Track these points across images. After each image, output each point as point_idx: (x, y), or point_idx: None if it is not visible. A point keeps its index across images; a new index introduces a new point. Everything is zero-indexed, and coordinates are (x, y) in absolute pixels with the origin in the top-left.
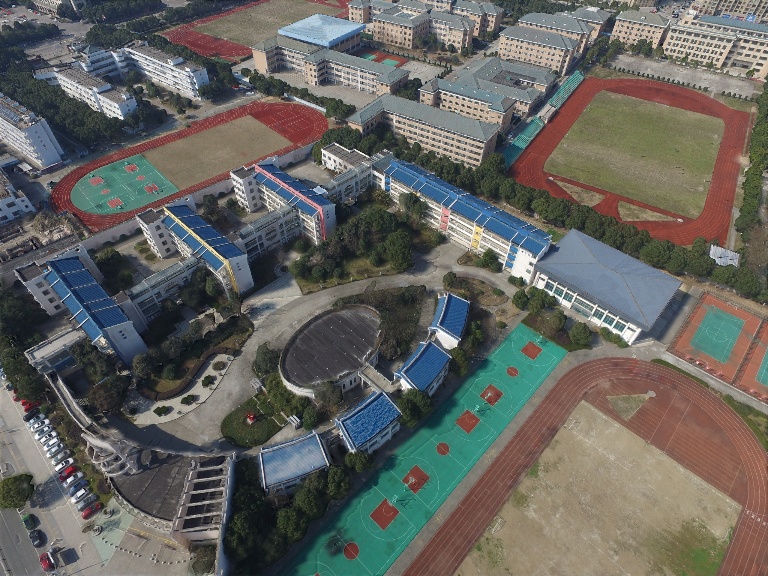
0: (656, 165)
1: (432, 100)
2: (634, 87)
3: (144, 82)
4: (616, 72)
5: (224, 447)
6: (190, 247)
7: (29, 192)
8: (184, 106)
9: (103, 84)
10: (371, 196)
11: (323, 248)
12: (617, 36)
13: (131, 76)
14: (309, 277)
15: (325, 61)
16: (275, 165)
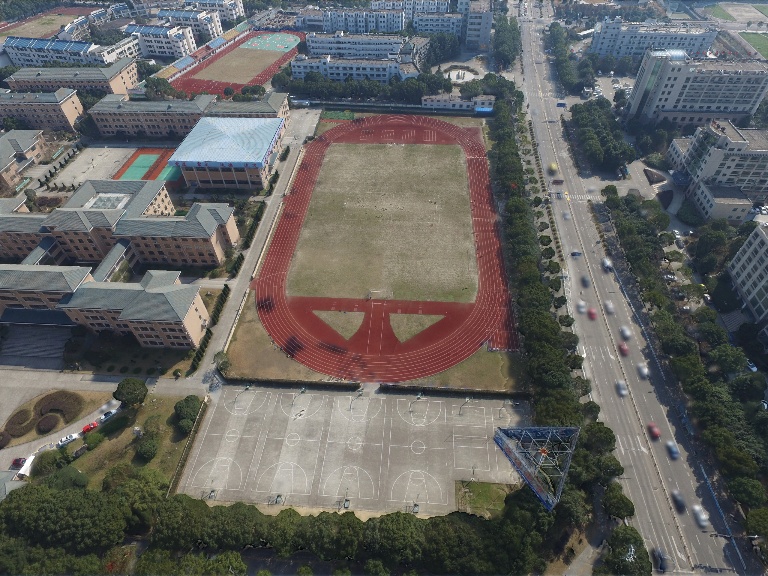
0: None
1: None
2: None
3: None
4: None
5: None
6: None
7: (316, 31)
8: None
9: (338, 32)
10: None
11: None
12: None
13: None
14: None
15: None
16: None
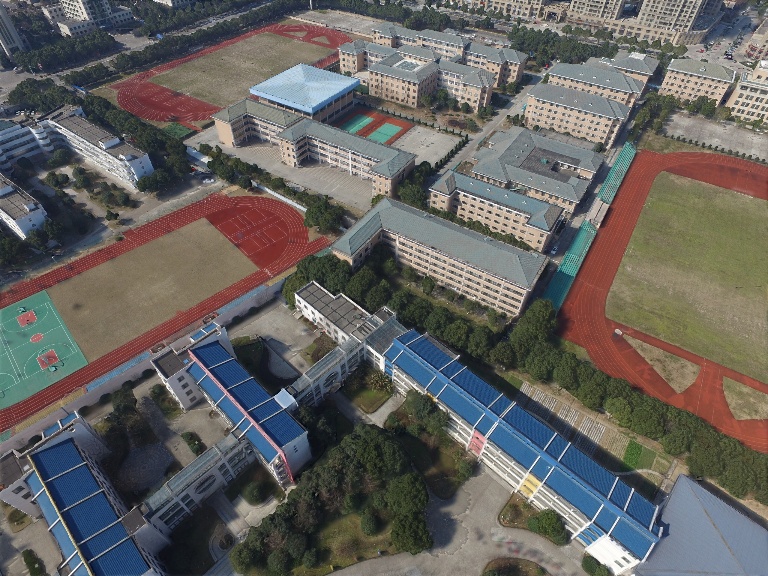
0: (760, 304)
1: (447, 203)
2: (701, 166)
3: (74, 163)
4: (674, 142)
5: None
6: (59, 547)
7: None
8: (119, 204)
9: (1, 186)
10: (364, 381)
11: (286, 521)
12: (668, 89)
13: (56, 157)
14: (263, 571)
15: (306, 137)
16: (222, 339)
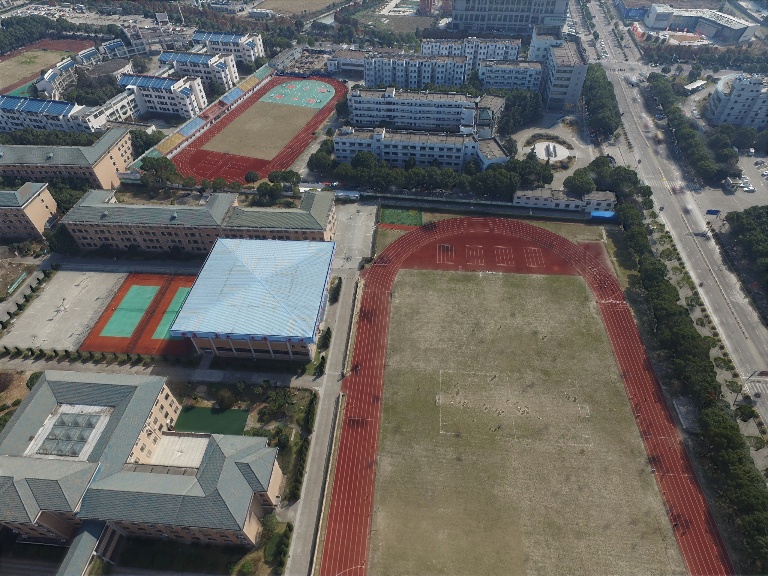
0: None
1: None
2: None
3: None
4: None
5: (148, 57)
6: None
7: (352, 77)
8: None
9: (389, 91)
10: None
11: None
12: None
13: None
14: None
15: None
16: None
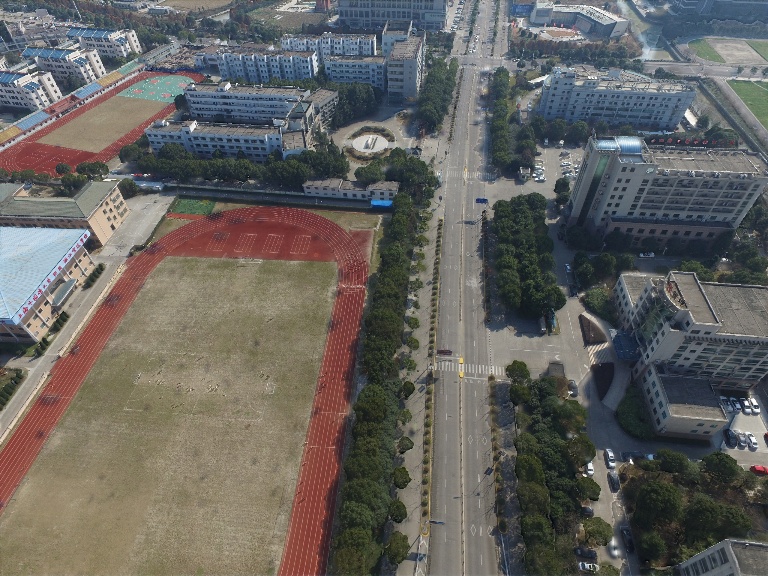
0: None
1: None
2: None
3: None
4: None
5: None
6: None
7: (218, 72)
8: None
9: (222, 85)
10: None
11: None
12: None
13: None
14: None
15: None
16: None
